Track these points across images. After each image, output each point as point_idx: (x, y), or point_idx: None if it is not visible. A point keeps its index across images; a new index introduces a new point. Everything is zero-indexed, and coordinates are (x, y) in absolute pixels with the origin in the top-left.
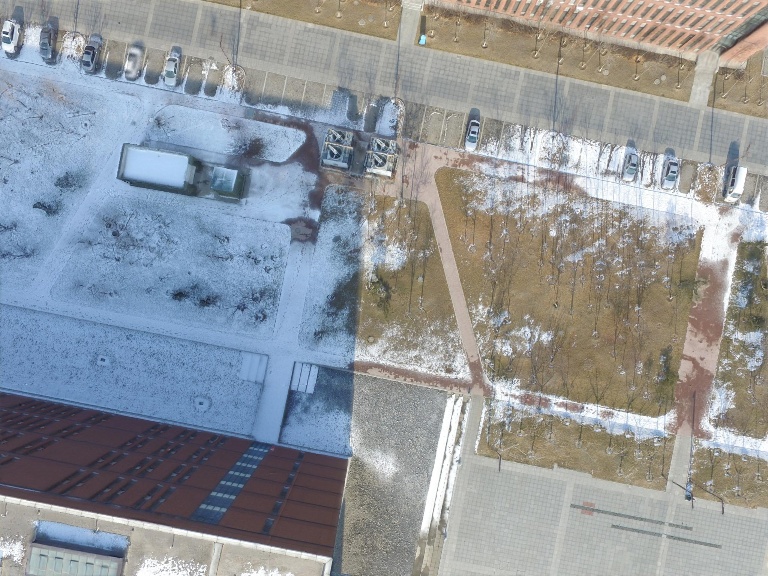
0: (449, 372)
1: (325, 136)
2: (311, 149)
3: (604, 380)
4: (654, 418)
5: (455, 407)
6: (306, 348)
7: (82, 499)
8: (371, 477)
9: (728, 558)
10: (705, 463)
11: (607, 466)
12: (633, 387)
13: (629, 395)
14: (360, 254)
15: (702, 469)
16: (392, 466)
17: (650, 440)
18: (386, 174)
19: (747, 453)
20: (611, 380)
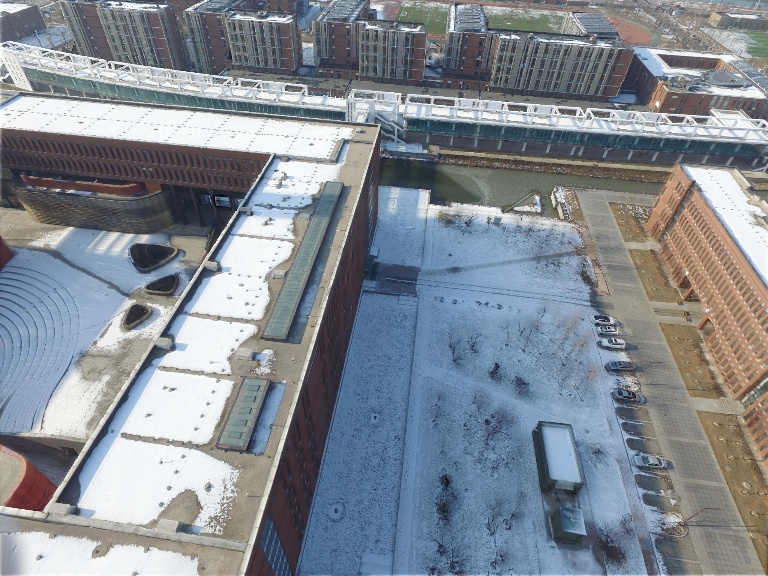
0: None
1: None
2: None
3: None
4: None
5: None
6: None
7: (298, 413)
8: None
9: None
10: None
11: None
12: None
13: None
14: None
15: None
16: None
17: None
18: None
19: None
20: None
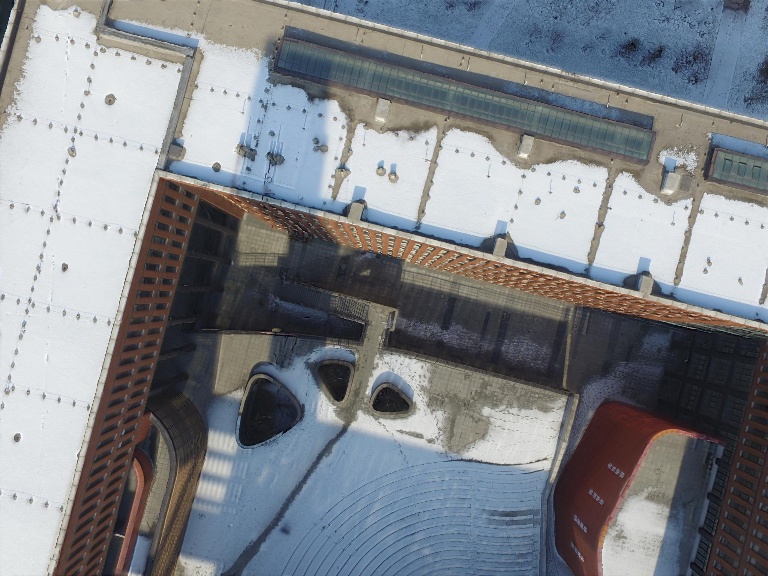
0: None
1: None
2: None
3: None
4: None
5: None
6: None
7: None
8: None
9: None
10: None
11: None
12: None
13: None
14: None
15: None
16: None
17: None
18: None
19: None
20: None
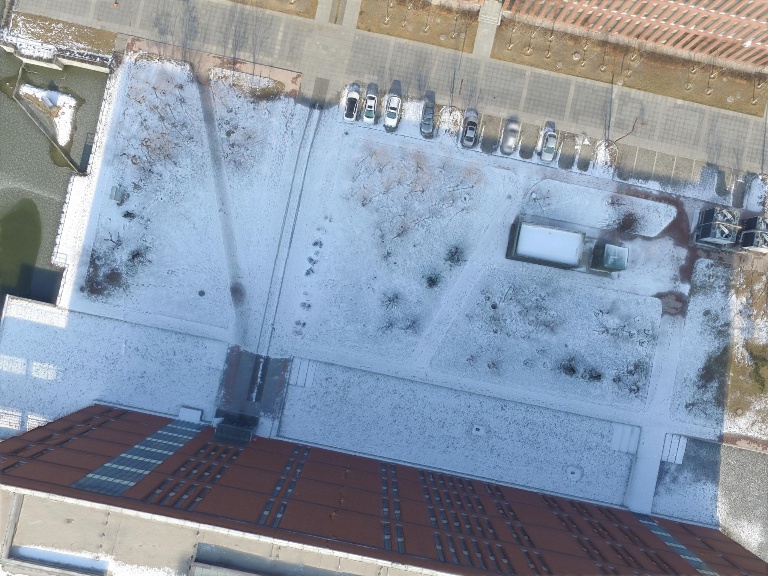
0: None
1: (695, 211)
2: (682, 224)
3: None
4: None
5: None
6: (677, 420)
7: None
8: None
9: None
10: None
11: None
12: None
13: None
14: (730, 328)
15: None
16: (758, 536)
17: None
18: (763, 251)
19: None
20: None
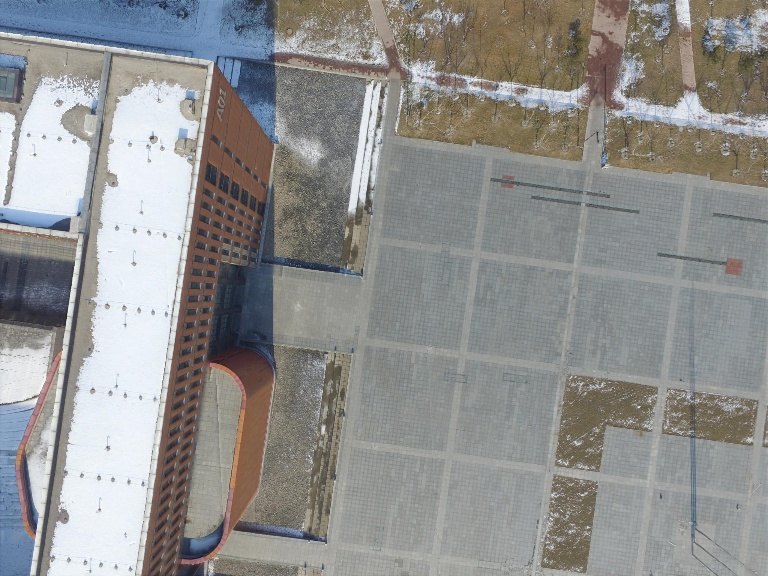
0: (366, 58)
1: None
2: None
3: (516, 56)
4: (567, 92)
5: (374, 92)
6: (228, 43)
7: None
8: (298, 164)
9: (646, 222)
10: (619, 132)
11: (524, 139)
12: (544, 61)
13: (541, 70)
14: None
15: (616, 137)
16: (317, 152)
17: (564, 111)
18: None
19: (659, 120)
20: (522, 56)
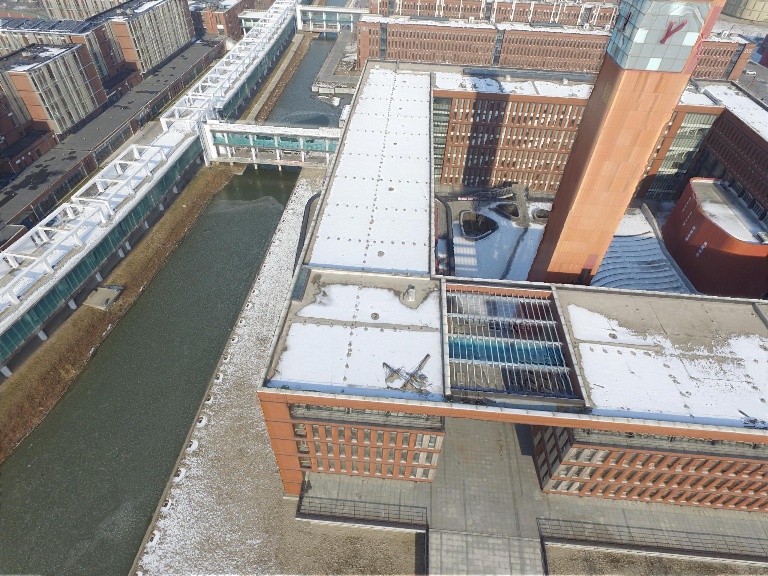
0: None
1: None
2: None
3: None
4: None
5: None
6: None
7: None
8: None
9: None
10: None
11: None
12: None
13: None
14: None
15: None
16: None
17: None
18: None
19: None
20: None
